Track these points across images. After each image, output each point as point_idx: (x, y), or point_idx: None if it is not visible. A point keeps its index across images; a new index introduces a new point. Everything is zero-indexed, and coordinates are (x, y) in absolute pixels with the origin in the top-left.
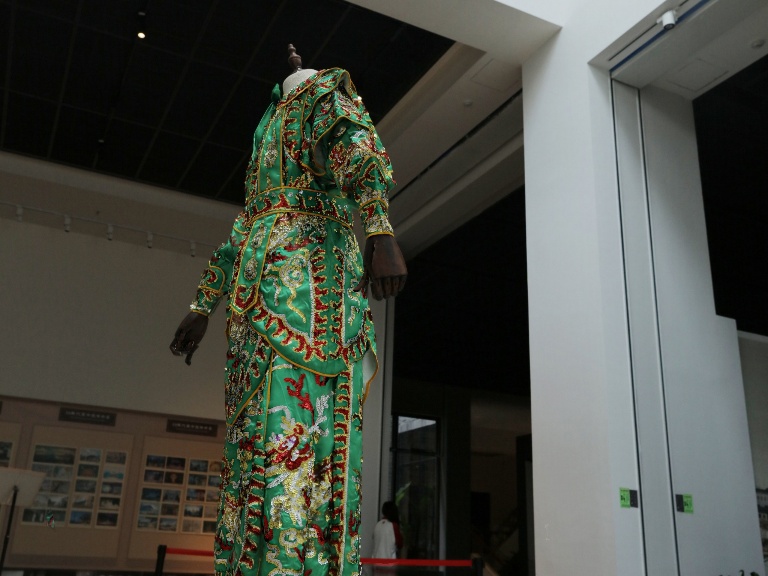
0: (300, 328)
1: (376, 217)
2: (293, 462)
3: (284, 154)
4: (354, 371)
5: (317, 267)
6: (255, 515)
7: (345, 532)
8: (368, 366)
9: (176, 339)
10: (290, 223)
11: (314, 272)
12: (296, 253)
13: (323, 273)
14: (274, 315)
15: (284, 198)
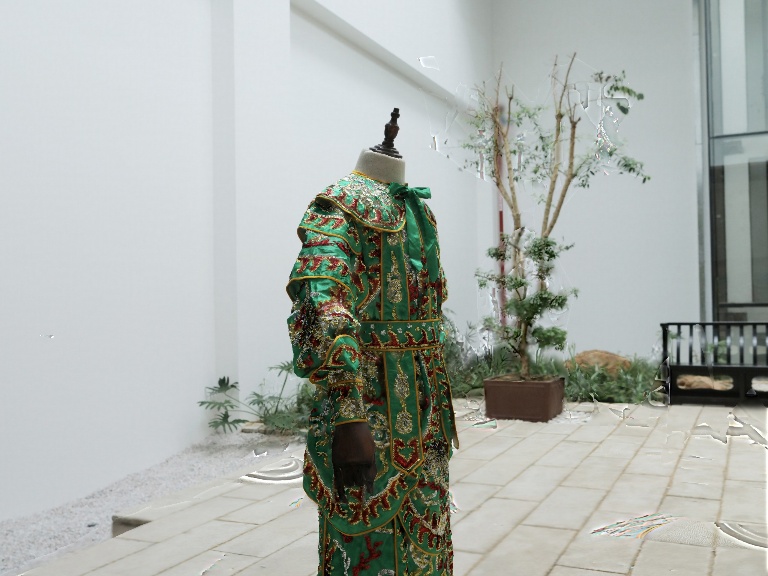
0: None
1: None
2: None
3: None
4: None
5: None
6: None
7: None
8: None
9: None
10: None
11: None
12: None
13: None
14: None
15: None
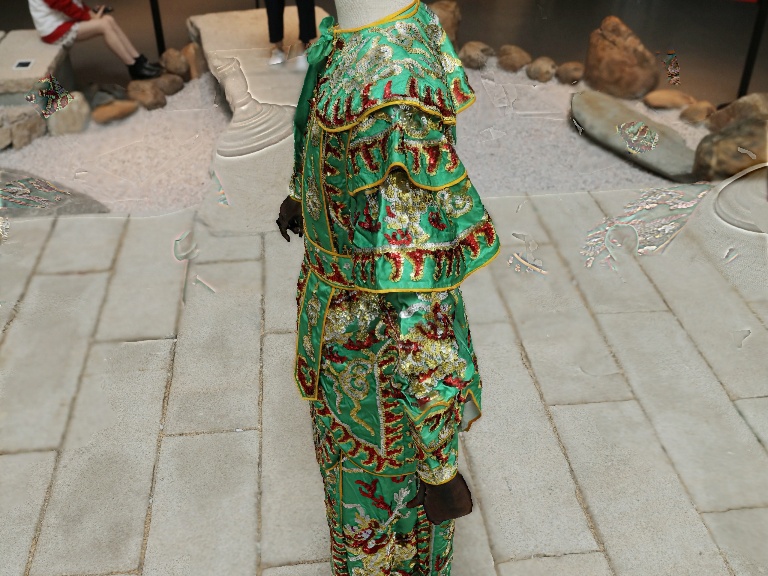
0: (369, 439)
1: (427, 468)
2: (370, 549)
3: (329, 212)
4: None
5: (385, 377)
6: (340, 569)
7: (431, 571)
8: (471, 409)
9: (280, 219)
10: (349, 308)
11: (382, 382)
12: (358, 357)
13: None
14: (338, 421)
15: (338, 271)
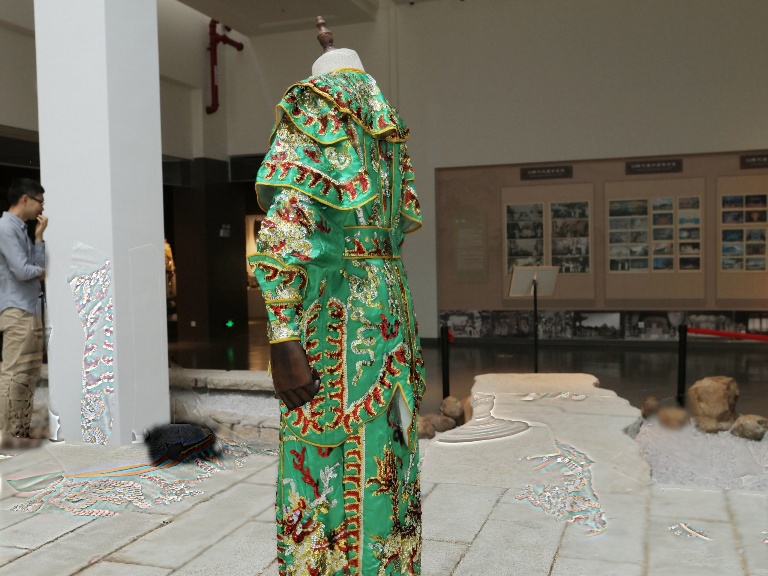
0: None
1: (268, 323)
2: (297, 536)
3: None
4: (367, 432)
5: (309, 330)
6: (282, 575)
7: None
8: (406, 411)
9: None
10: None
11: (307, 336)
12: None
13: (314, 337)
14: None
15: None
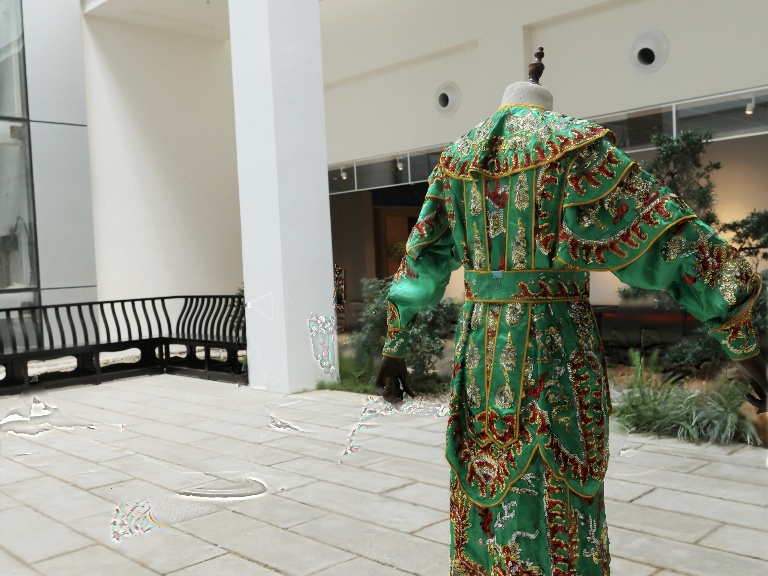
0: None
1: None
2: None
3: None
4: None
5: None
6: None
7: None
8: (456, 454)
9: None
10: None
11: None
12: None
13: None
14: None
15: None
